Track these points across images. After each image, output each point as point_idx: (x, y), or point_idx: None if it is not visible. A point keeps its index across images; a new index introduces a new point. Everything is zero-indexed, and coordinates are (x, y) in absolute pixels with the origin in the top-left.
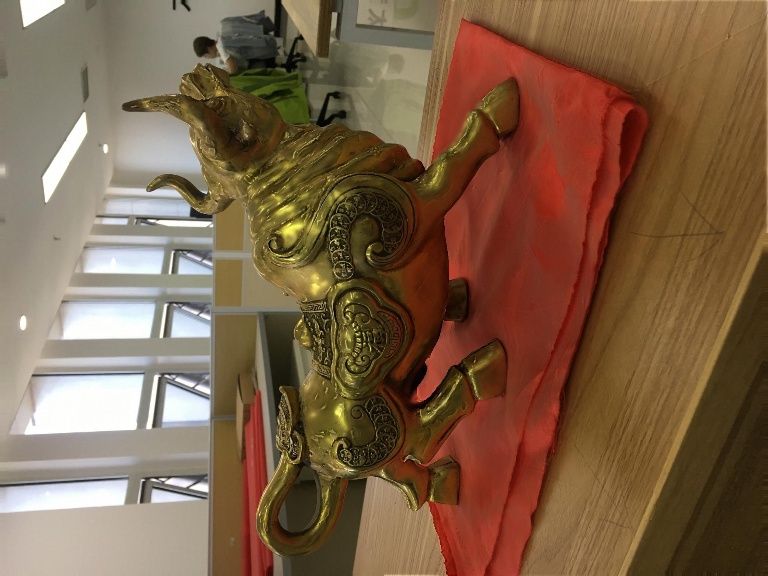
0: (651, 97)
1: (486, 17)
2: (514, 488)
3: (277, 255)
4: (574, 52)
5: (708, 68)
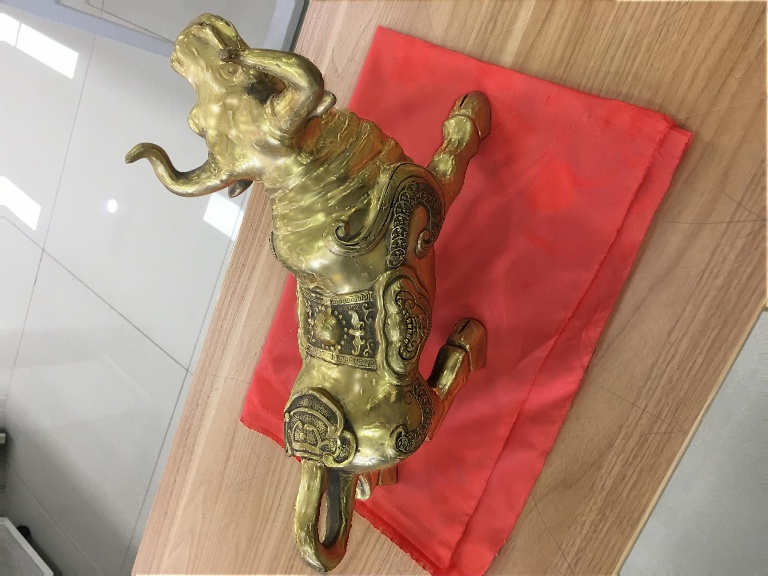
0: (685, 127)
1: (418, 31)
2: (509, 442)
3: (343, 243)
4: (577, 82)
5: (747, 114)
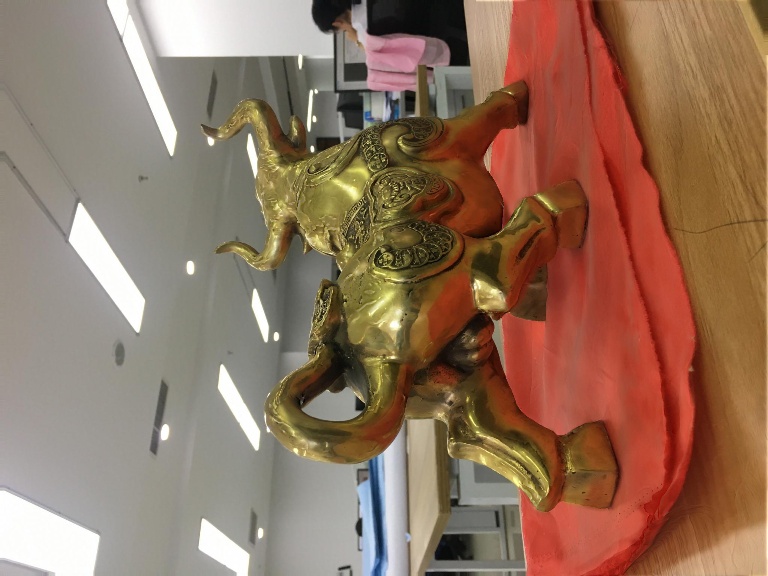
0: None
1: None
2: (629, 223)
3: (315, 174)
4: None
5: None
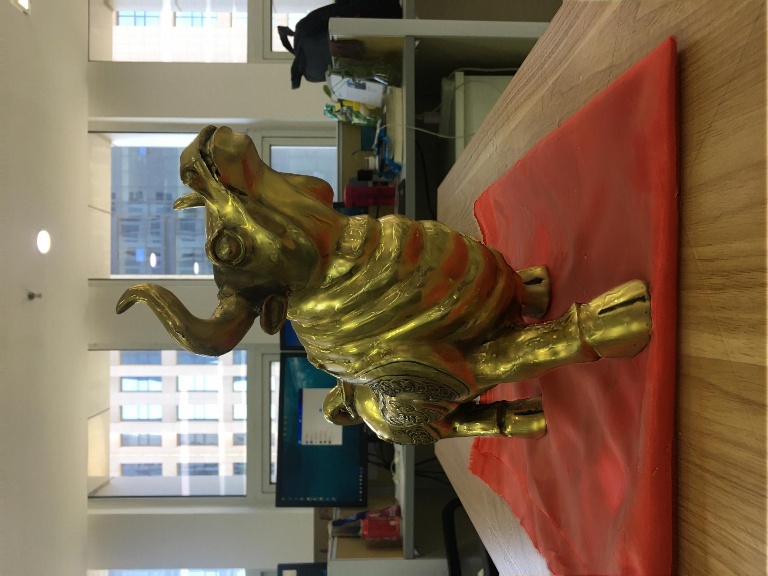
0: None
1: (691, 126)
2: None
3: None
4: (689, 494)
5: None
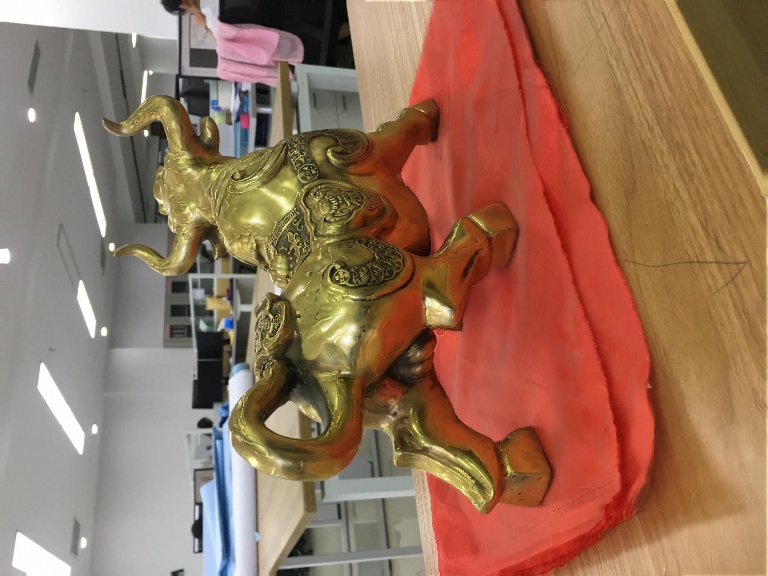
0: None
1: None
2: (570, 250)
3: (240, 181)
4: None
5: None
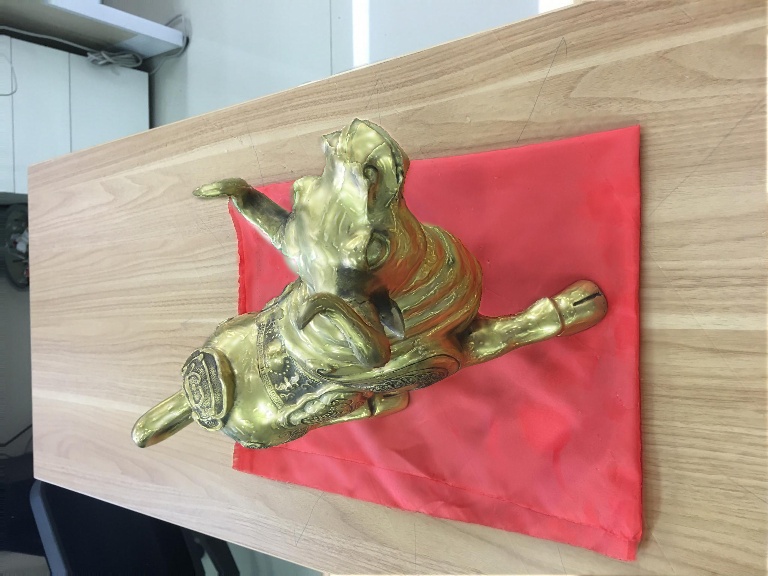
0: (646, 542)
1: (653, 184)
2: None
3: None
4: (654, 416)
5: None
